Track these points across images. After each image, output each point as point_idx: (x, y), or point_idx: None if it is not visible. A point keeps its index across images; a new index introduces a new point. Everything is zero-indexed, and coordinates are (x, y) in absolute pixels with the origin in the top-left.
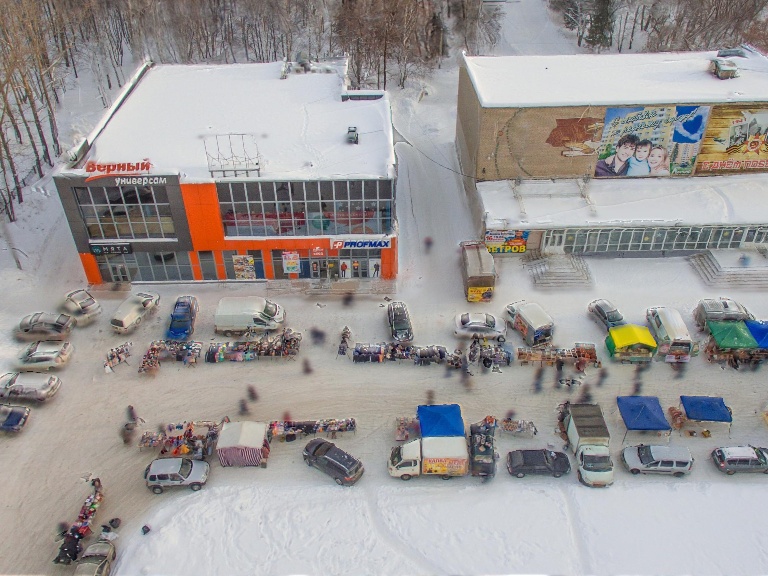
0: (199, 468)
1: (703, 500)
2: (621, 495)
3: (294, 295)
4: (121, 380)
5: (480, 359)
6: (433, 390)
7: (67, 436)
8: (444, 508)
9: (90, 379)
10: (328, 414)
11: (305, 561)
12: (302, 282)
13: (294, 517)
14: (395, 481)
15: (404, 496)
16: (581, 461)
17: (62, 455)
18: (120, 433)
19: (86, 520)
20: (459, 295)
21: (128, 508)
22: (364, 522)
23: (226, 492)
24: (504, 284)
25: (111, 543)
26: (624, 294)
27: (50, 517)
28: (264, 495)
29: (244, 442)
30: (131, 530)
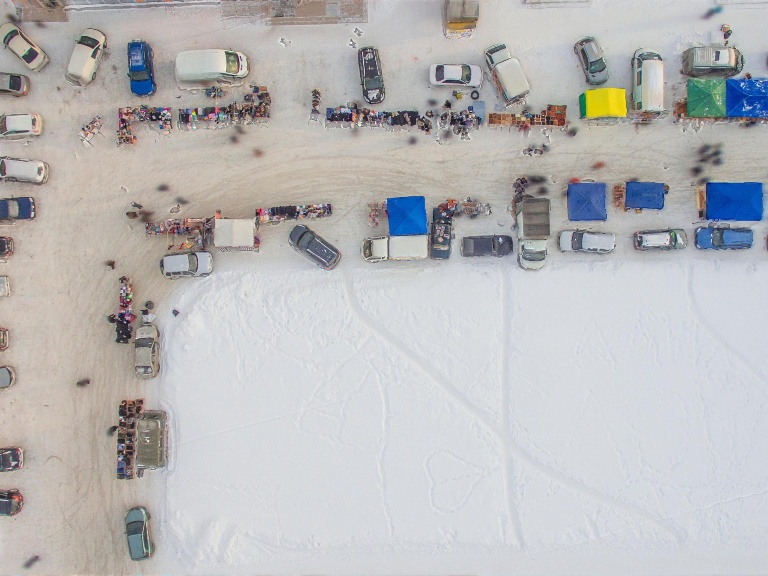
0: (204, 261)
1: (611, 279)
2: (547, 275)
3: (254, 26)
4: (103, 157)
5: (450, 126)
6: (402, 164)
7: (78, 223)
8: (405, 291)
9: (73, 156)
10: (306, 193)
11: (301, 336)
12: (260, 5)
13: (288, 302)
14: (367, 263)
15: (374, 279)
16: (521, 251)
17: (82, 244)
18: (124, 219)
19: (127, 309)
20: (437, 28)
21: (155, 292)
22: (343, 303)
23: (230, 278)
24: (489, 5)
25: (153, 325)
26: (619, 20)
27: (97, 302)
28: (262, 279)
29: (237, 243)
30: (164, 311)
